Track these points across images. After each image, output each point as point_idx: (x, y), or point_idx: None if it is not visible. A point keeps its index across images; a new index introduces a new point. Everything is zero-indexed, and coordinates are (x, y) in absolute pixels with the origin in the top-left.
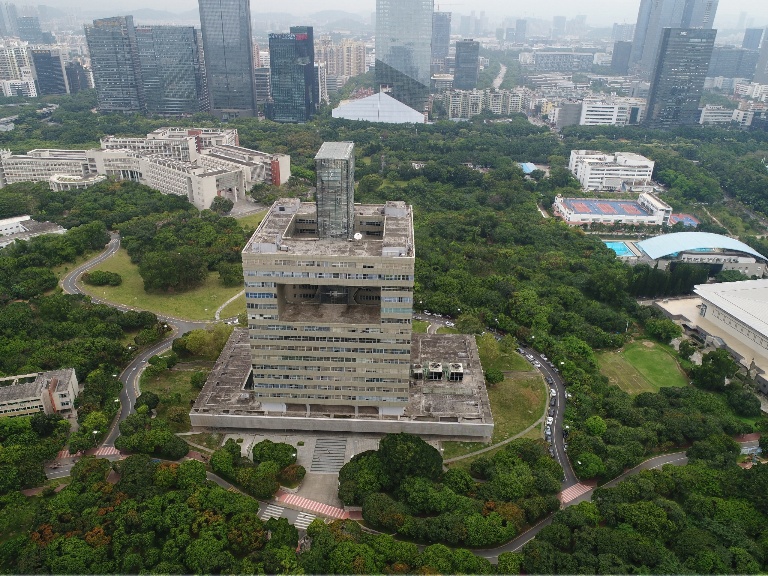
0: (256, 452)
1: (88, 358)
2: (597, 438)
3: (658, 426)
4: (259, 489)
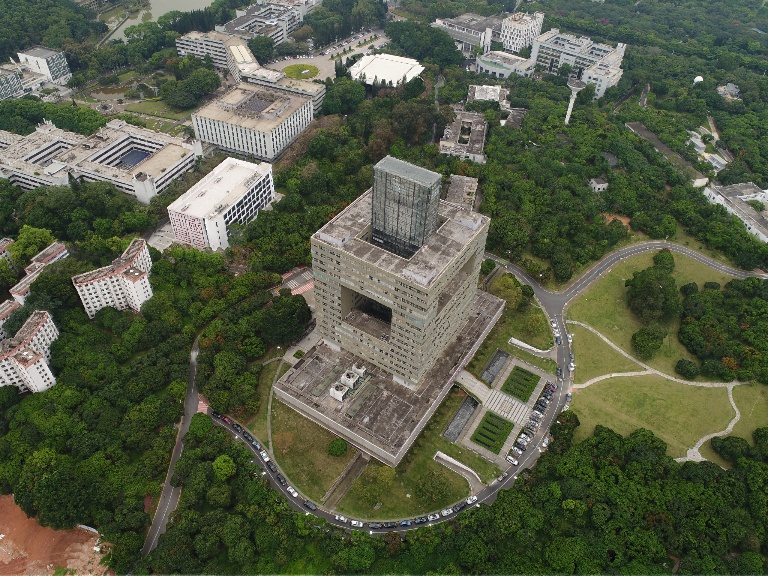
0: None
1: (497, 230)
2: (211, 447)
3: (183, 520)
4: None
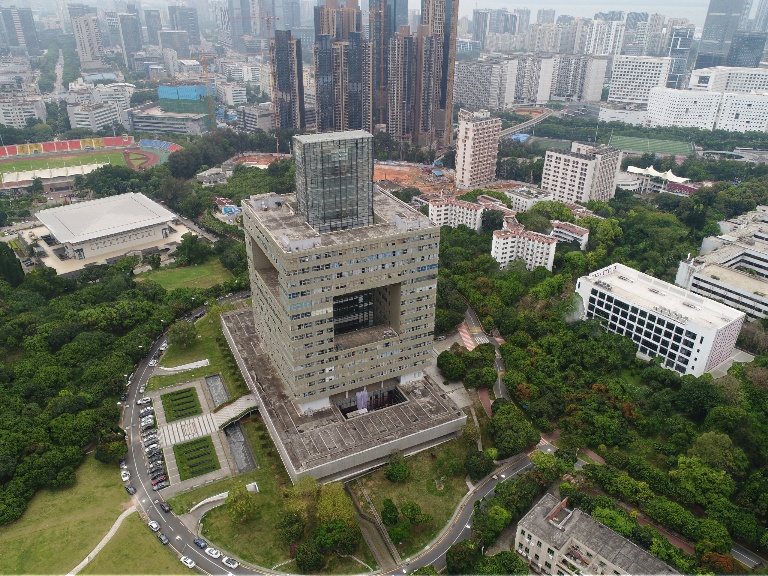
0: (464, 365)
1: None
2: None
3: None
4: (493, 345)
